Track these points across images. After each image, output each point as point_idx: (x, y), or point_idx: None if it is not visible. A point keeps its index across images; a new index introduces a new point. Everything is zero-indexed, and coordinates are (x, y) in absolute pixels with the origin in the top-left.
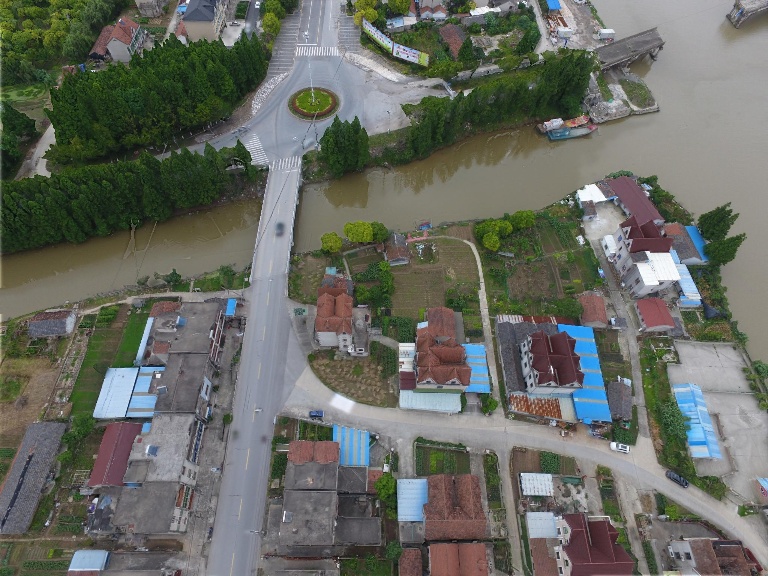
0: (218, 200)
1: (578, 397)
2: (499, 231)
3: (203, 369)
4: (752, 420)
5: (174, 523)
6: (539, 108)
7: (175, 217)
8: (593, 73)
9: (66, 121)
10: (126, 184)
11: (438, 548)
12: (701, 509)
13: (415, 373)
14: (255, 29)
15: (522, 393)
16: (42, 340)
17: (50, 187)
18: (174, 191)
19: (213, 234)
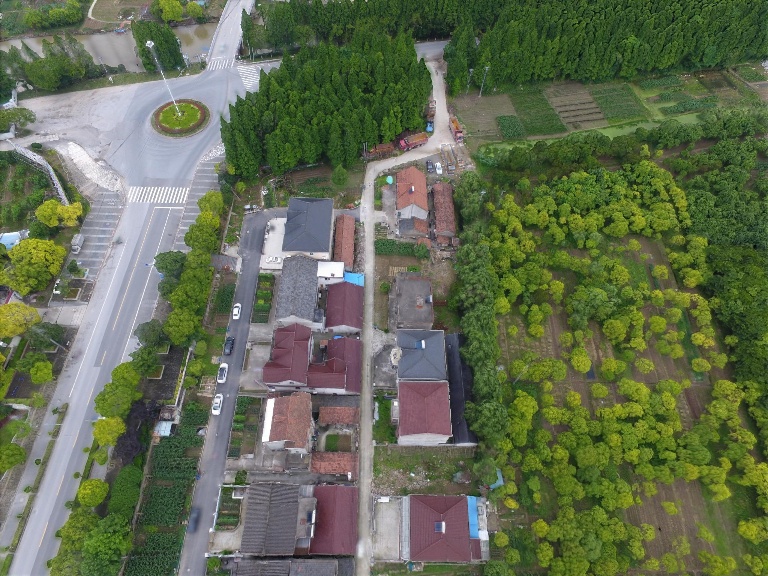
0: None
1: None
2: None
3: None
4: None
5: None
6: None
7: None
8: None
9: None
10: None
11: None
12: None
13: None
14: (244, 255)
15: None
16: None
17: None
18: None
19: None
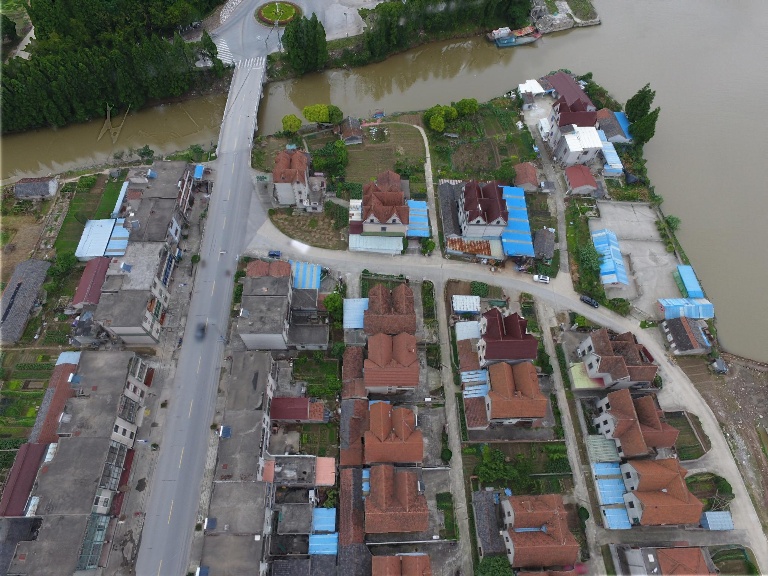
0: (188, 94)
1: (506, 239)
2: (445, 115)
3: (172, 210)
4: (660, 260)
5: (147, 323)
6: (487, 17)
7: (148, 108)
8: None
9: (44, 16)
10: (101, 68)
11: (374, 338)
12: (608, 323)
13: None
14: None
15: (457, 236)
16: (27, 202)
17: (31, 67)
18: (146, 76)
19: (185, 131)
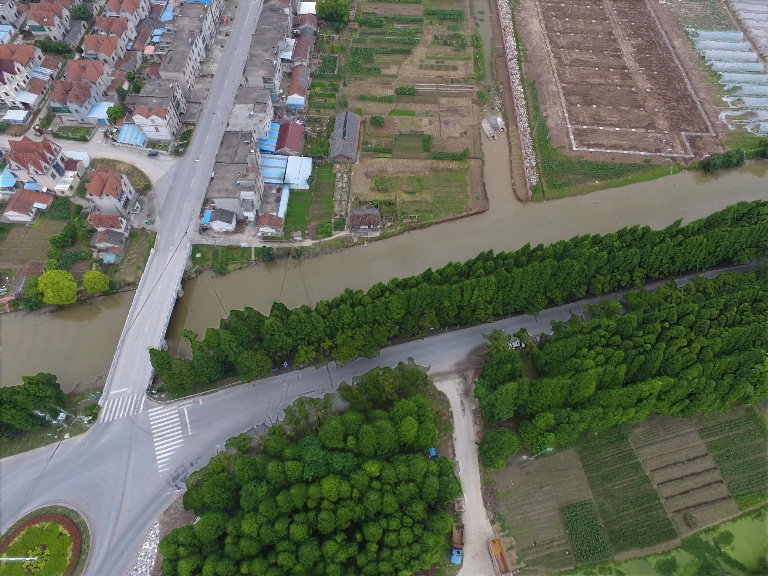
0: None
1: None
2: None
3: (219, 154)
4: None
5: None
6: None
7: None
8: None
9: None
10: None
11: None
12: None
13: (64, 167)
14: None
15: None
16: None
17: None
18: None
19: None
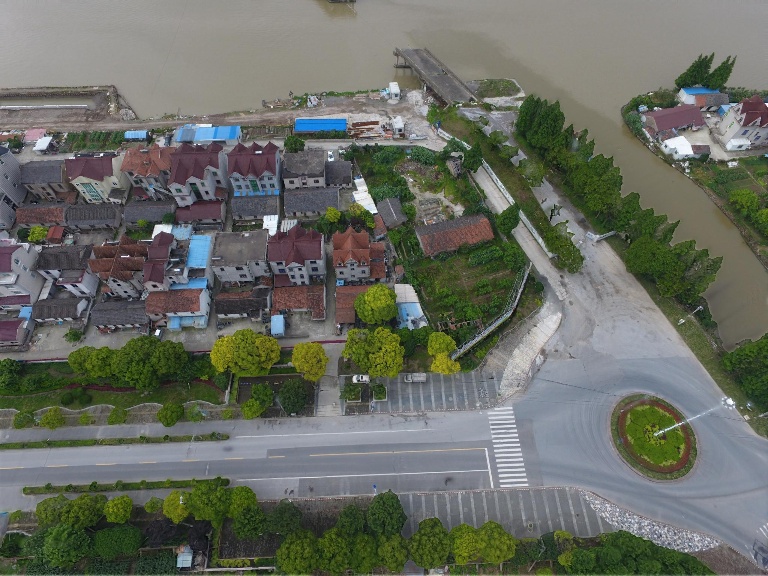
0: None
1: None
2: None
3: None
4: None
5: None
6: None
7: None
8: (493, 111)
9: None
10: None
11: None
12: None
13: None
14: None
15: None
16: None
17: None
18: None
19: None
